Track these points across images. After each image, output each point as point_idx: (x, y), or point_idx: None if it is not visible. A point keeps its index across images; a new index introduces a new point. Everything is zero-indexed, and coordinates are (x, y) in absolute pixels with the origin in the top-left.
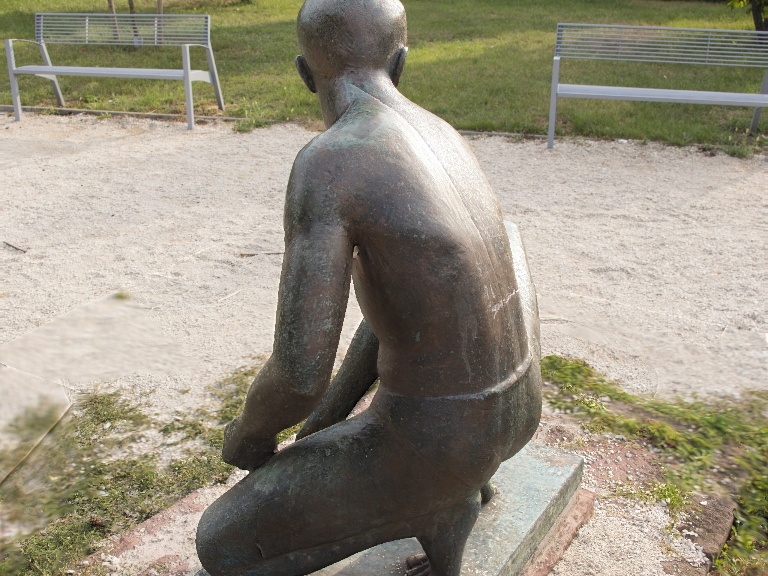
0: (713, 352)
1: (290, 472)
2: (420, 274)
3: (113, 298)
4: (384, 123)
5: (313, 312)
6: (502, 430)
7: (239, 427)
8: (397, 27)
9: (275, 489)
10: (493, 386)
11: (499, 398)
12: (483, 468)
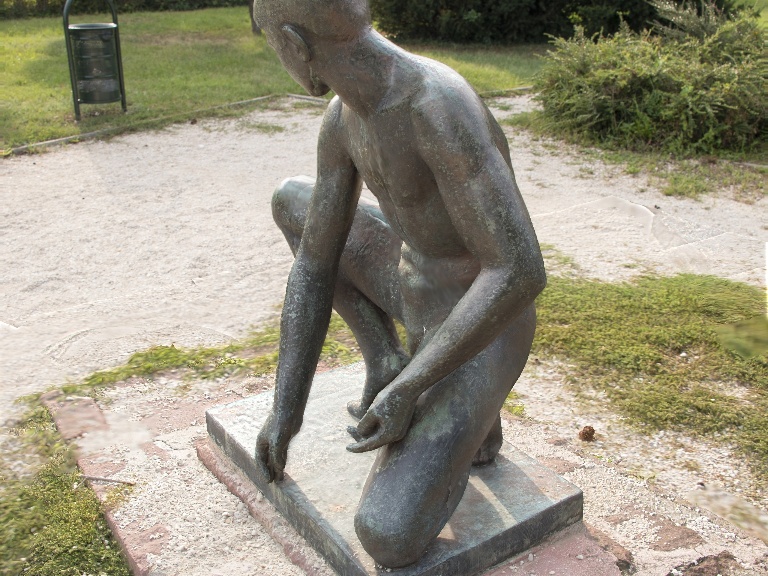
0: (214, 298)
1: (459, 400)
2: None
3: None
4: None
5: (528, 216)
6: None
7: (411, 390)
8: None
9: (455, 422)
10: None
11: None
12: None
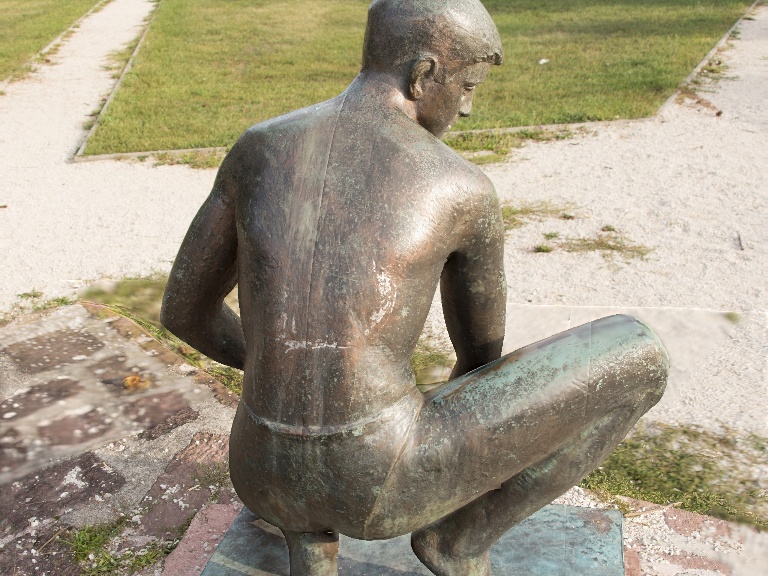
0: None
1: None
2: (241, 269)
3: (723, 315)
4: (301, 121)
5: None
6: (279, 474)
7: None
8: (414, 31)
9: None
10: (272, 420)
11: (273, 436)
12: (256, 495)
